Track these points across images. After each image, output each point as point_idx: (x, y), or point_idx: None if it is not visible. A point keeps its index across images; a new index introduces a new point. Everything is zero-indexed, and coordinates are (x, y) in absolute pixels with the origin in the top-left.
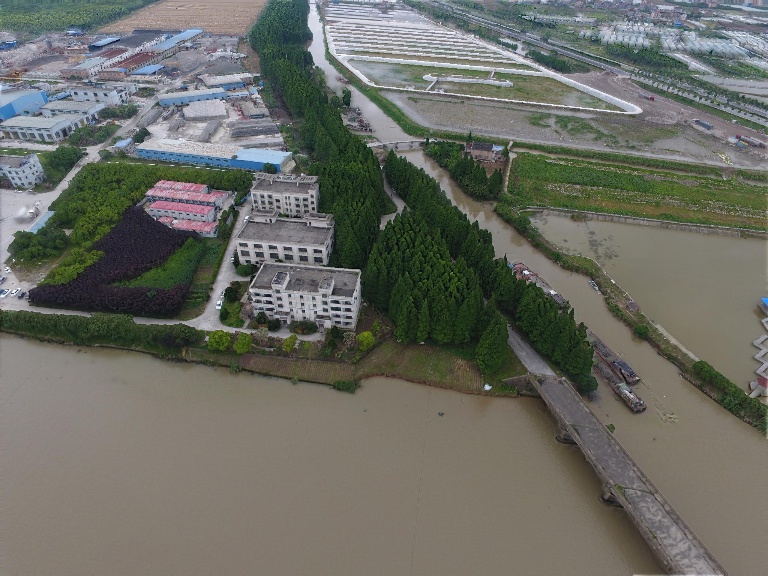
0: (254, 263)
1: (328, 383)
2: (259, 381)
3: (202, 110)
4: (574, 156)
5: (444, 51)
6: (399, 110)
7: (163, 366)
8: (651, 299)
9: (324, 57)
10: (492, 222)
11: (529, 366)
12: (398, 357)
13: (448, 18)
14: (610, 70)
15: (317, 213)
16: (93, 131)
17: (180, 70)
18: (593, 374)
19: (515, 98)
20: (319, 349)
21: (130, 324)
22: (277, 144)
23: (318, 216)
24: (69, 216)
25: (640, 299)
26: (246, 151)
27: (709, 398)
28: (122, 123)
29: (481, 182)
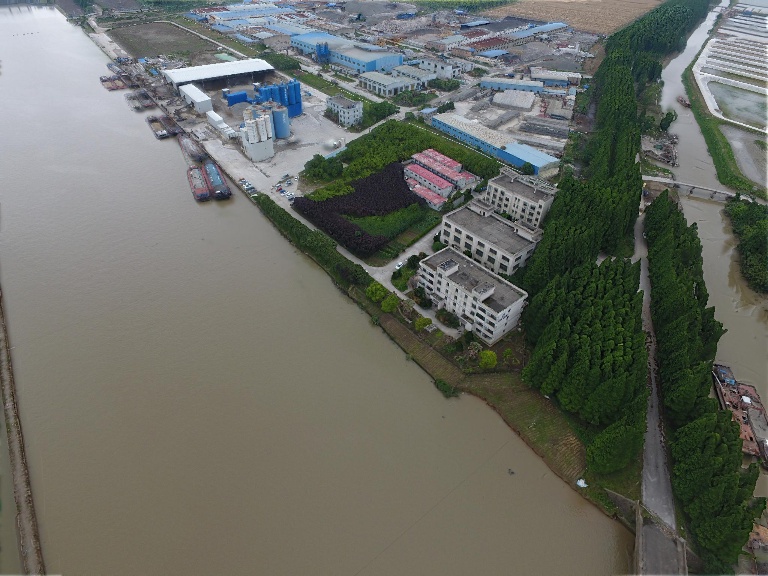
0: (450, 245)
1: (433, 376)
2: (384, 341)
3: (511, 99)
4: None
5: None
6: (730, 152)
7: (333, 291)
8: None
9: (682, 73)
10: (757, 322)
11: (647, 496)
12: (512, 394)
13: None
14: None
15: None
16: (414, 95)
17: (520, 59)
18: (745, 570)
19: None
20: (446, 344)
21: (331, 248)
22: (556, 148)
23: (529, 227)
24: (352, 155)
25: None
26: (518, 146)
27: None
28: (441, 94)
29: None
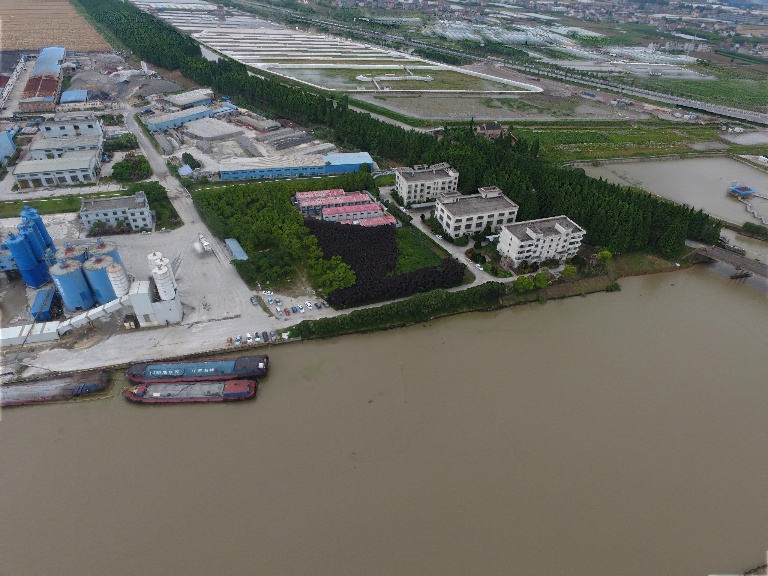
0: (461, 235)
1: (602, 290)
2: (563, 303)
3: (211, 129)
4: (542, 126)
5: (341, 54)
6: (384, 108)
7: (492, 316)
8: (687, 201)
9: None
10: None
11: (691, 246)
12: (618, 264)
13: (299, 23)
14: None
15: (487, 187)
16: (134, 164)
17: (107, 93)
18: None
19: (449, 89)
20: (576, 273)
21: None
22: (331, 149)
23: (488, 189)
24: (261, 238)
25: (681, 202)
26: (330, 157)
27: (760, 240)
28: (138, 153)
29: (526, 151)
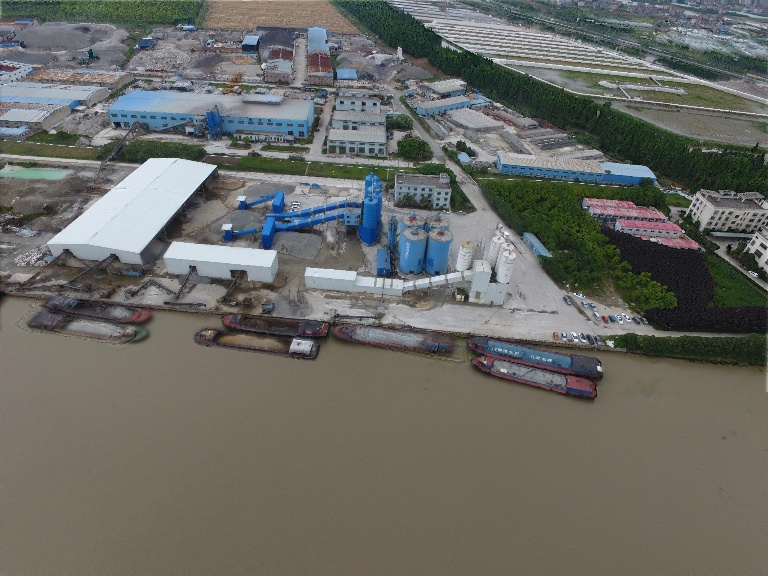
0: None
1: None
2: None
3: (474, 120)
4: None
5: (575, 56)
6: (641, 119)
7: None
8: None
9: None
10: None
11: None
12: None
13: (522, 19)
14: (742, 78)
15: None
16: (419, 145)
17: (370, 74)
18: None
19: (709, 106)
20: None
21: None
22: (598, 156)
23: None
24: (562, 238)
25: None
26: (608, 165)
27: None
28: (414, 134)
29: None
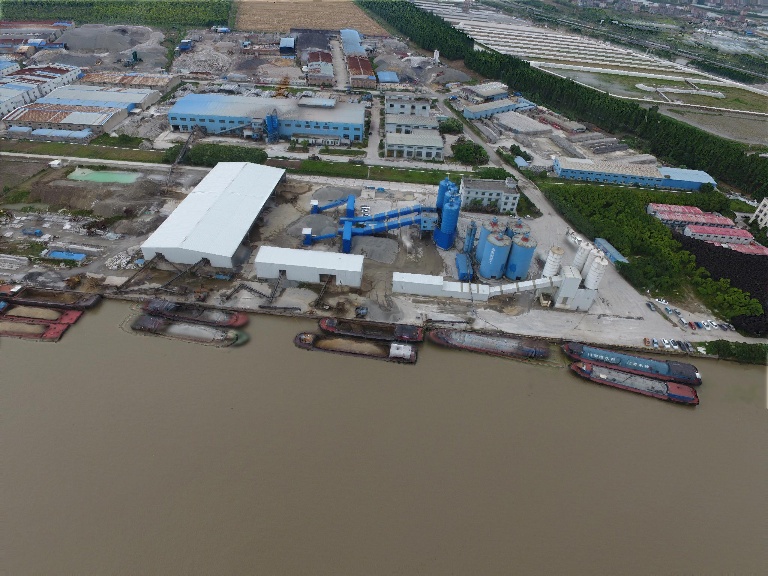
0: None
1: None
2: None
3: (522, 124)
4: None
5: (607, 58)
6: (686, 123)
7: None
8: None
9: None
10: None
11: None
12: None
13: (547, 21)
14: None
15: None
16: None
17: (409, 77)
18: None
19: (750, 110)
20: None
21: None
22: (652, 161)
23: None
24: (636, 243)
25: None
26: (667, 170)
27: None
28: (465, 138)
29: None
